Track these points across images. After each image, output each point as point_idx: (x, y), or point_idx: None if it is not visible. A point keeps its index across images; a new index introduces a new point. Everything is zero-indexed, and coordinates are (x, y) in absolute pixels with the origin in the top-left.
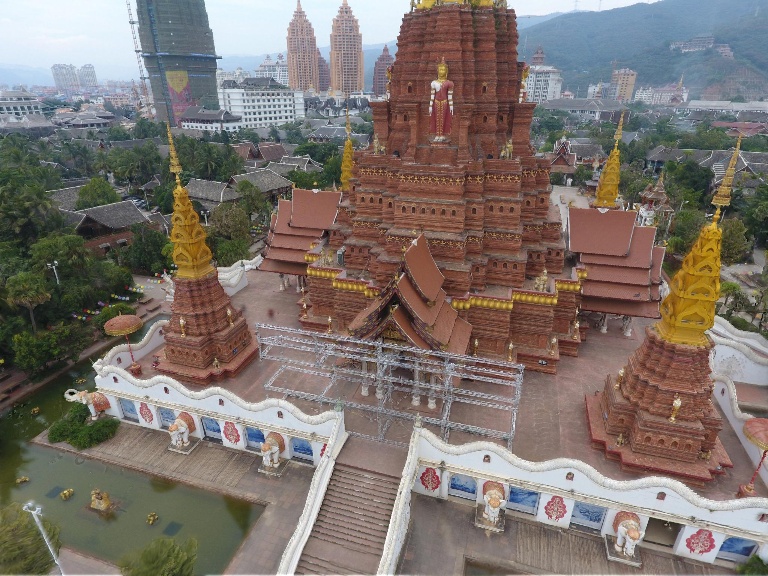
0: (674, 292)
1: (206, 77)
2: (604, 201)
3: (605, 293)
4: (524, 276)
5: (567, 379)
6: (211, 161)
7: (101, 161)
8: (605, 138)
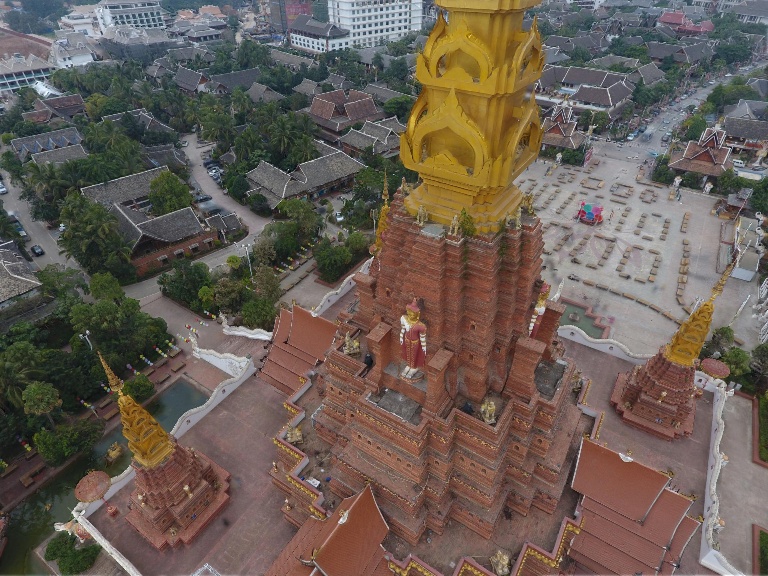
0: None
1: None
2: (628, 452)
3: (599, 556)
4: (490, 533)
5: None
6: (285, 137)
7: (192, 113)
8: None
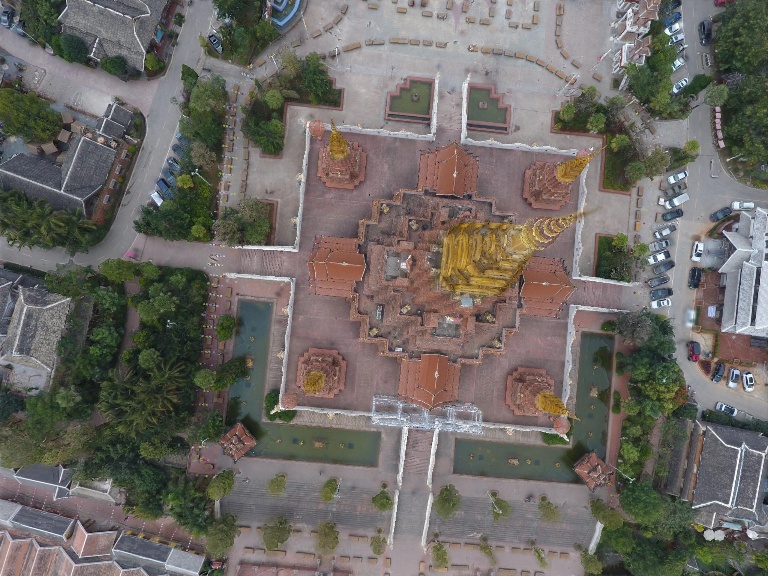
0: (546, 407)
1: None
2: None
3: (533, 313)
4: None
5: (502, 356)
6: None
7: None
8: None
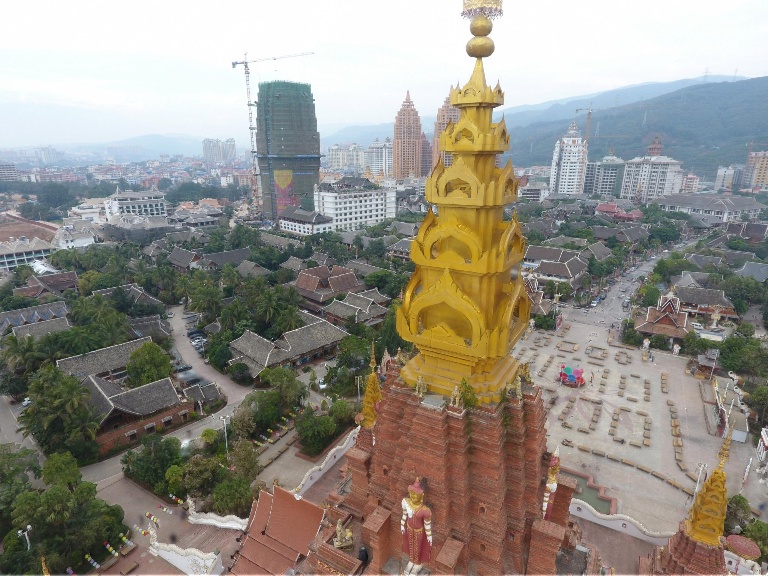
0: None
1: (309, 174)
2: None
3: None
4: None
5: None
6: (271, 307)
7: (182, 287)
8: (729, 287)
